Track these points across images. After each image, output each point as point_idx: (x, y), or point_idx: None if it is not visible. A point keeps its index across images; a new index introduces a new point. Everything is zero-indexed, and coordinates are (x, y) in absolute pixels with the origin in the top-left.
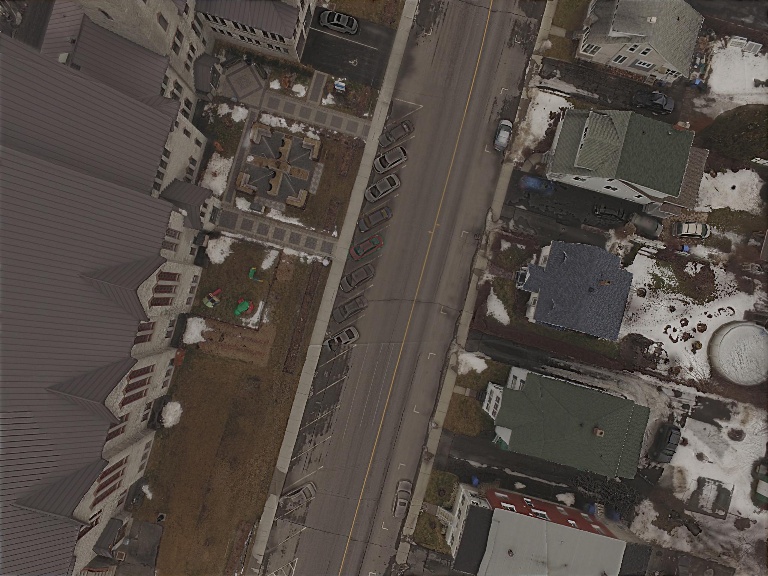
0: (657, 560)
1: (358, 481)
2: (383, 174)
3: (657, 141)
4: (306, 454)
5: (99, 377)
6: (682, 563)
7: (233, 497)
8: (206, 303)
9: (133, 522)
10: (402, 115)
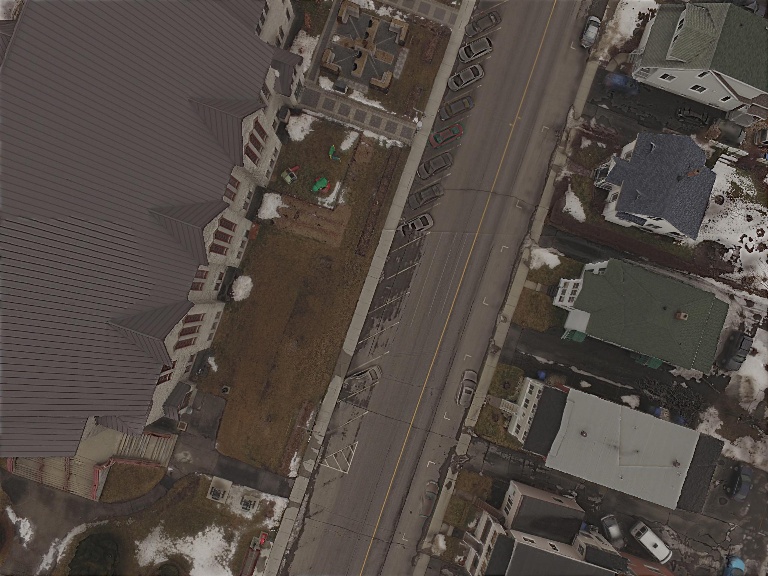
0: (719, 469)
1: (423, 369)
2: (467, 64)
3: (754, 35)
4: (373, 338)
5: (196, 210)
6: (745, 472)
7: (298, 375)
8: (285, 176)
9: (197, 393)
10: (490, 6)
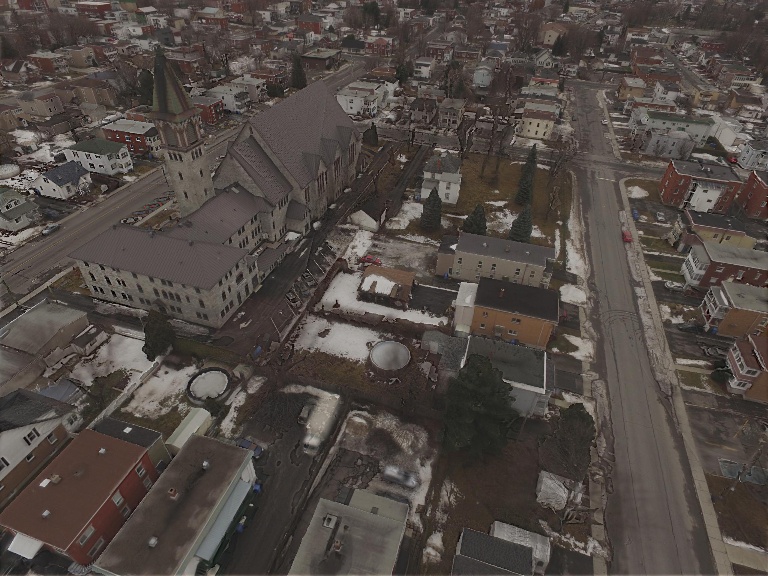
0: None
1: None
2: None
3: None
4: None
5: None
6: None
7: None
8: None
9: None
10: None
